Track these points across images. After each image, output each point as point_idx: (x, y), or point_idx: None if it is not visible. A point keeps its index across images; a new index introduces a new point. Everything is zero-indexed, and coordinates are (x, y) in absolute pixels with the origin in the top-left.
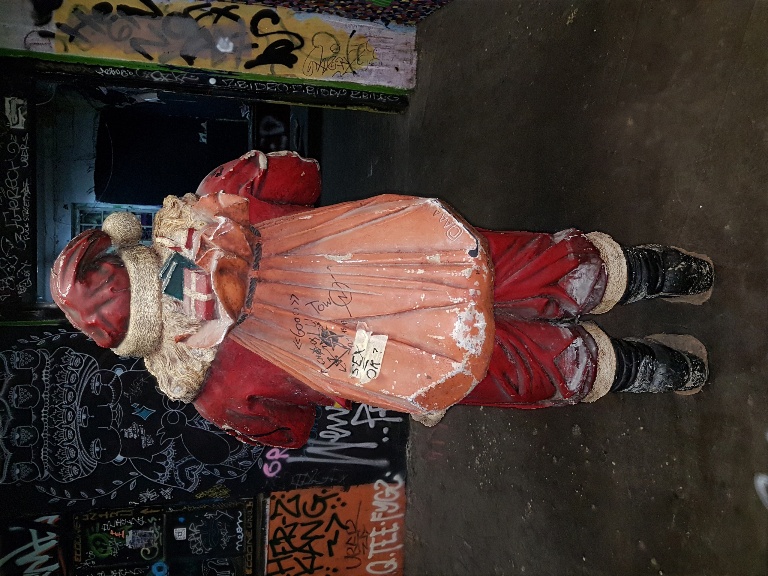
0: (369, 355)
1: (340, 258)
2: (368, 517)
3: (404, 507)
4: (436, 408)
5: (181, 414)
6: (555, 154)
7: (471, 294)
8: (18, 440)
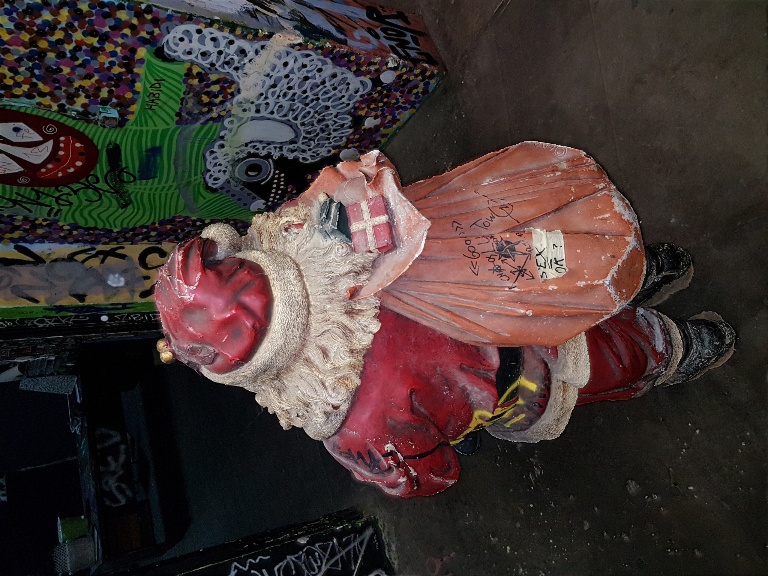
0: (550, 253)
1: None
2: None
3: None
4: (624, 297)
5: None
6: None
7: (607, 181)
8: None
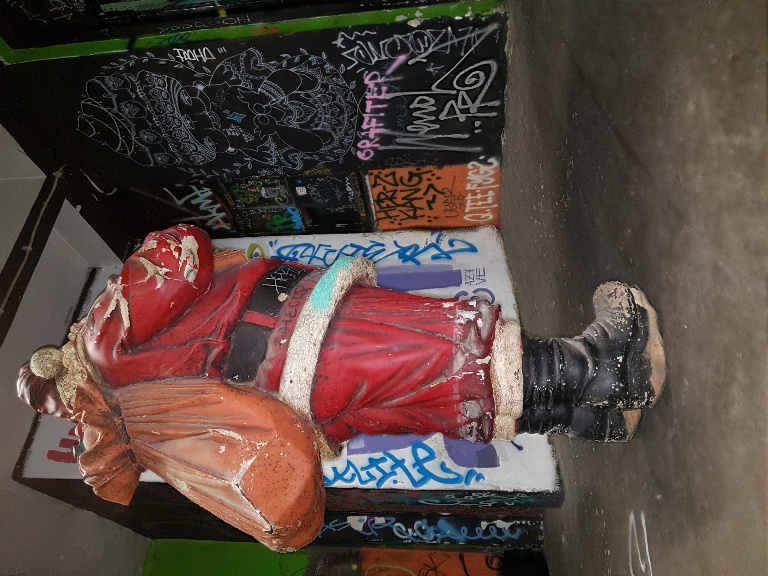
0: None
1: (183, 484)
2: (463, 187)
3: (499, 180)
4: None
5: (269, 117)
6: (632, 5)
7: (274, 544)
8: (148, 139)
